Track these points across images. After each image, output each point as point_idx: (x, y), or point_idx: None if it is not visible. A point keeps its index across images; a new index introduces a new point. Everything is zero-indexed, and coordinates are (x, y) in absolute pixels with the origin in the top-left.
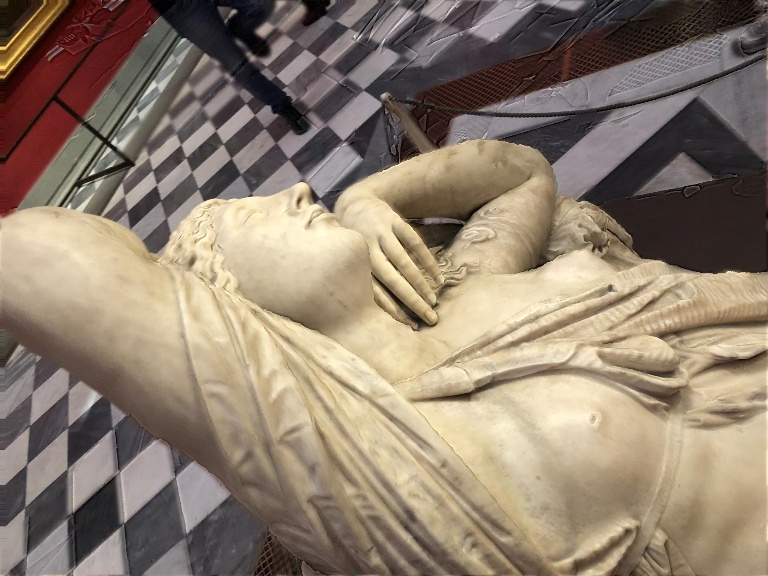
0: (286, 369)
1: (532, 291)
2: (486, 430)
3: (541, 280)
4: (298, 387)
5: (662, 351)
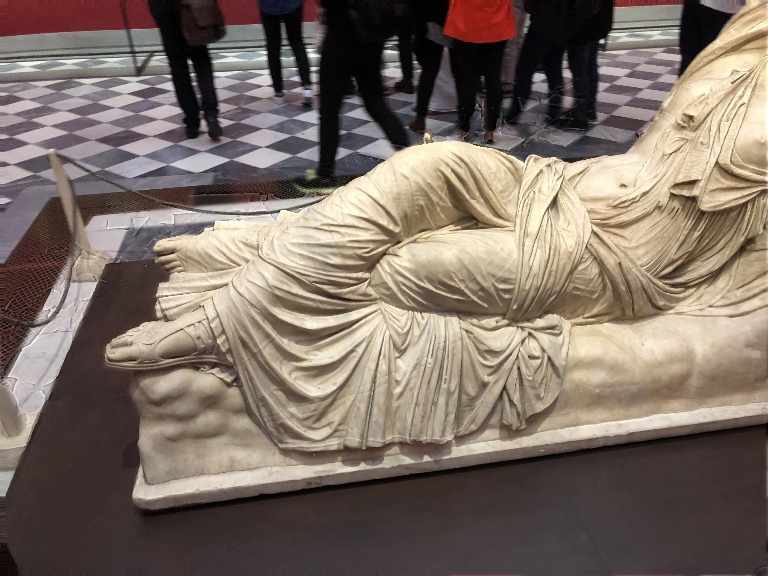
0: (761, 2)
1: (764, 122)
2: (717, 73)
3: (765, 125)
4: (754, 6)
5: (688, 109)
